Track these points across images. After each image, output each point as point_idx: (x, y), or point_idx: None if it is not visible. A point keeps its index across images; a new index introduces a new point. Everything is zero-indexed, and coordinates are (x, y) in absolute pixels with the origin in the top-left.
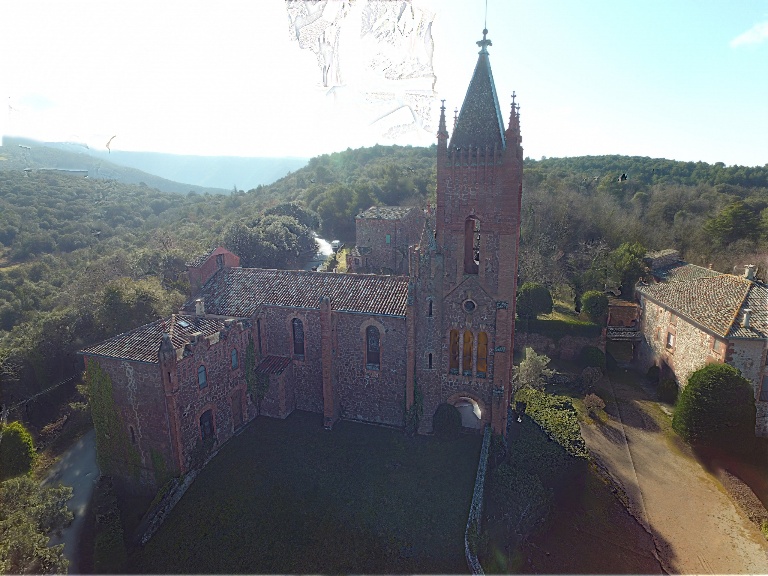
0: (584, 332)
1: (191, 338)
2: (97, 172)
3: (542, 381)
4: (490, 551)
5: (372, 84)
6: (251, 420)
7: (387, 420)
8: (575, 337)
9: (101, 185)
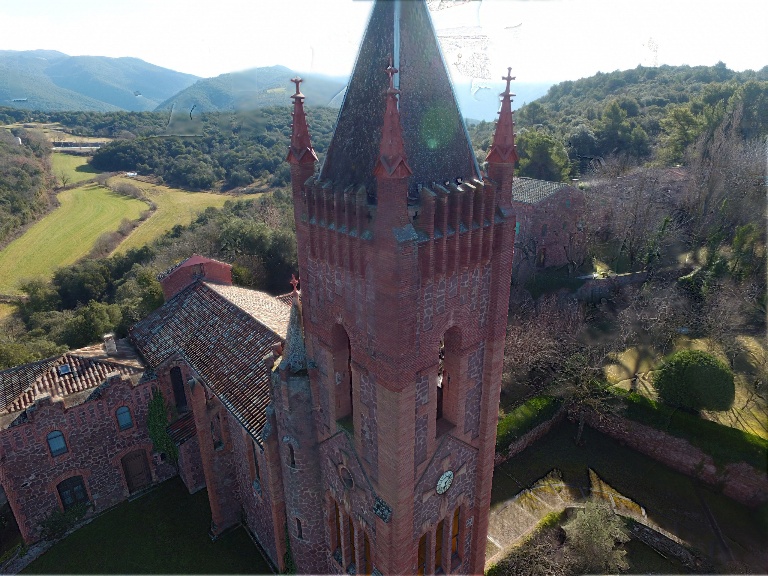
0: None
1: None
2: (240, 130)
3: None
4: None
5: None
6: (164, 480)
7: (275, 561)
8: (761, 471)
9: (244, 143)
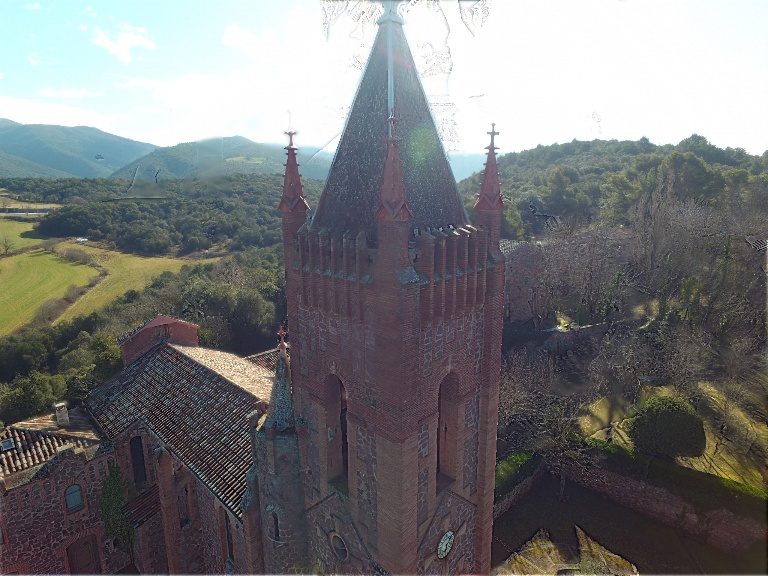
0: (762, 513)
1: None
2: (204, 193)
3: None
4: None
5: (352, 93)
6: (116, 571)
7: None
8: (741, 516)
9: (208, 206)
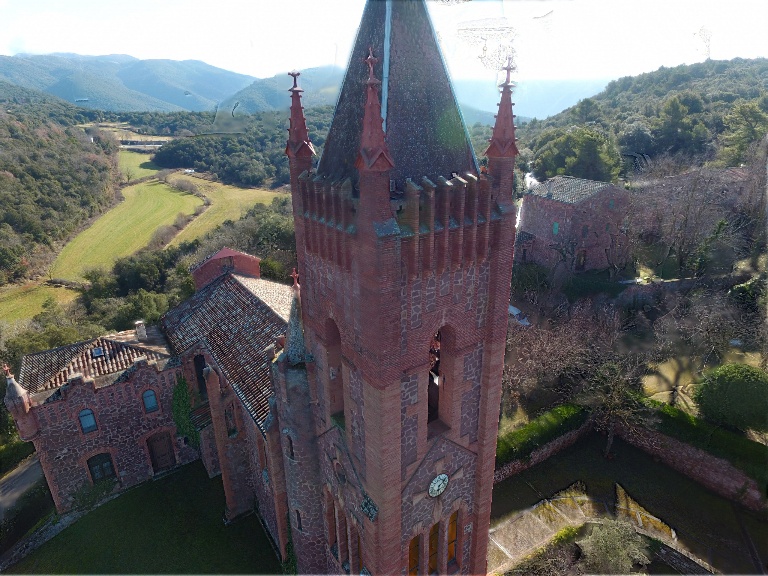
0: None
1: None
2: (283, 128)
3: None
4: None
5: None
6: (187, 463)
7: None
8: None
9: None
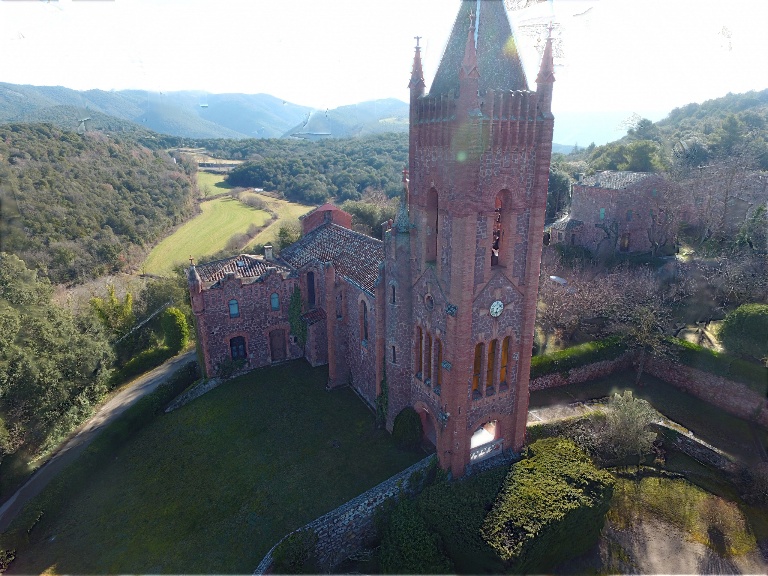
0: None
1: (225, 275)
2: (359, 134)
3: (648, 446)
4: (310, 568)
5: None
6: (294, 359)
7: (372, 402)
8: None
9: (362, 145)
